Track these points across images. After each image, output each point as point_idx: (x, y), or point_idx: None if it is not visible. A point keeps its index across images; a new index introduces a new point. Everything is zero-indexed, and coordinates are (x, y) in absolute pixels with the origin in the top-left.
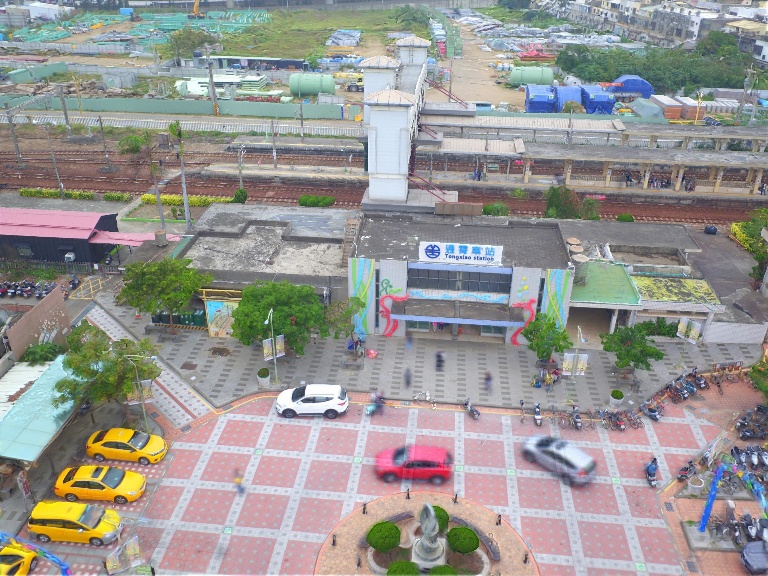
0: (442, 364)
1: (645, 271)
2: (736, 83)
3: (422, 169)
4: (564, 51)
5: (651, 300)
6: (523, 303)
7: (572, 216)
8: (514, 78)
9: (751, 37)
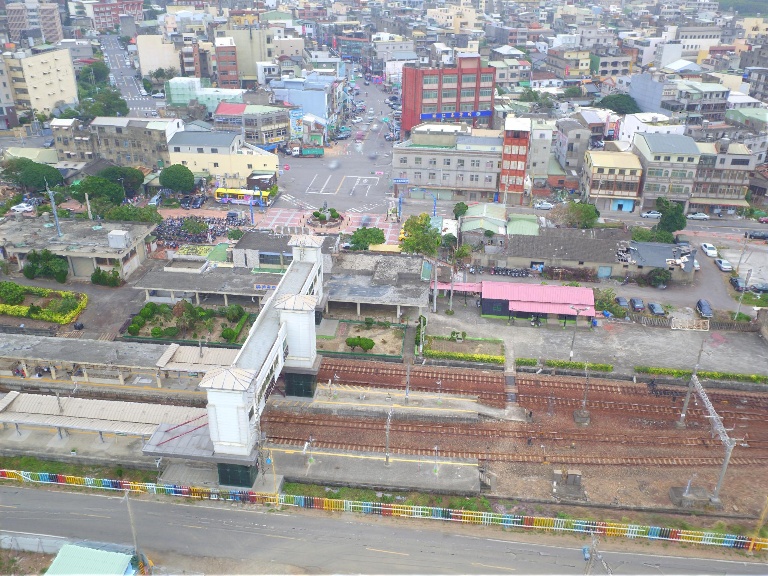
0: None
1: (194, 262)
2: None
3: None
4: None
5: (213, 245)
6: None
7: None
8: None
9: None
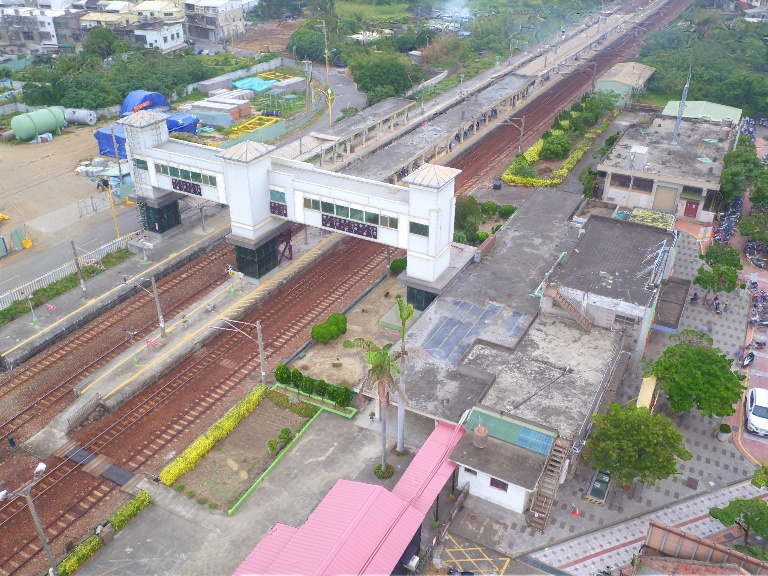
0: None
1: None
2: (210, 74)
3: None
4: (29, 84)
5: None
6: None
7: None
8: (27, 130)
9: (124, 28)
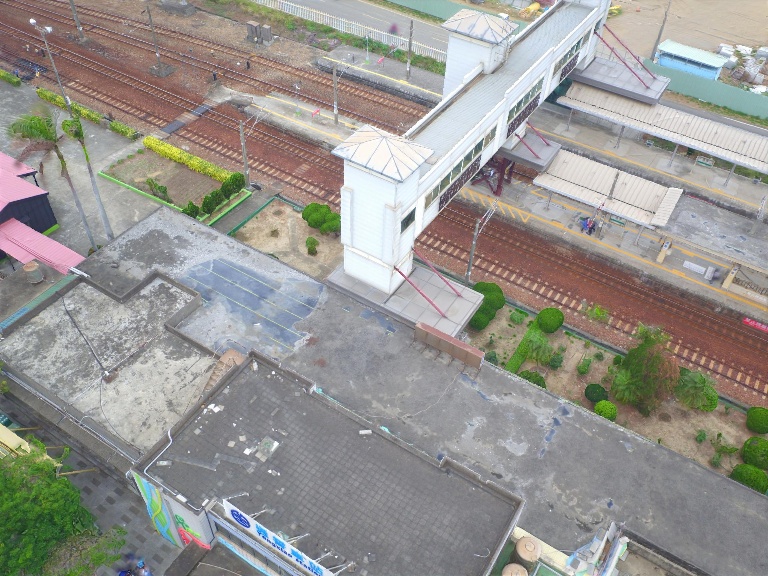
0: None
1: None
2: None
3: (535, 173)
4: None
5: None
6: None
7: None
8: None
9: None
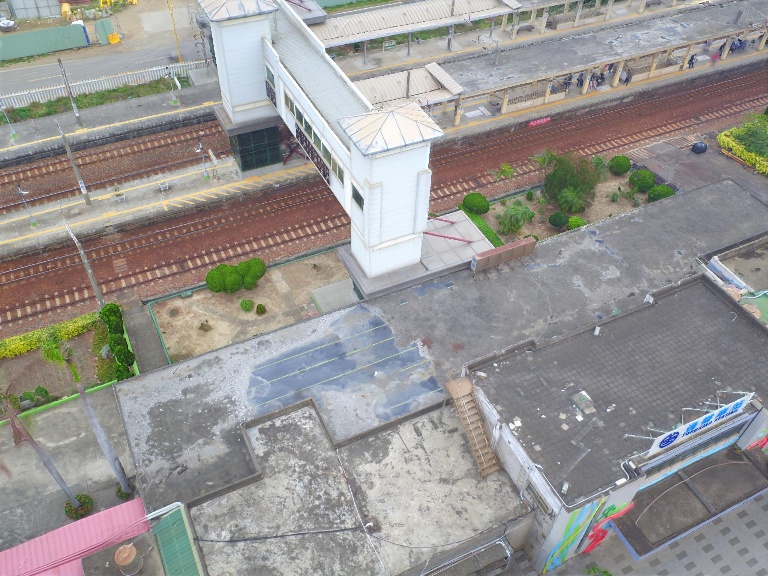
0: (698, 572)
1: None
2: None
3: None
4: None
5: None
6: (760, 440)
7: (590, 191)
8: None
9: None
